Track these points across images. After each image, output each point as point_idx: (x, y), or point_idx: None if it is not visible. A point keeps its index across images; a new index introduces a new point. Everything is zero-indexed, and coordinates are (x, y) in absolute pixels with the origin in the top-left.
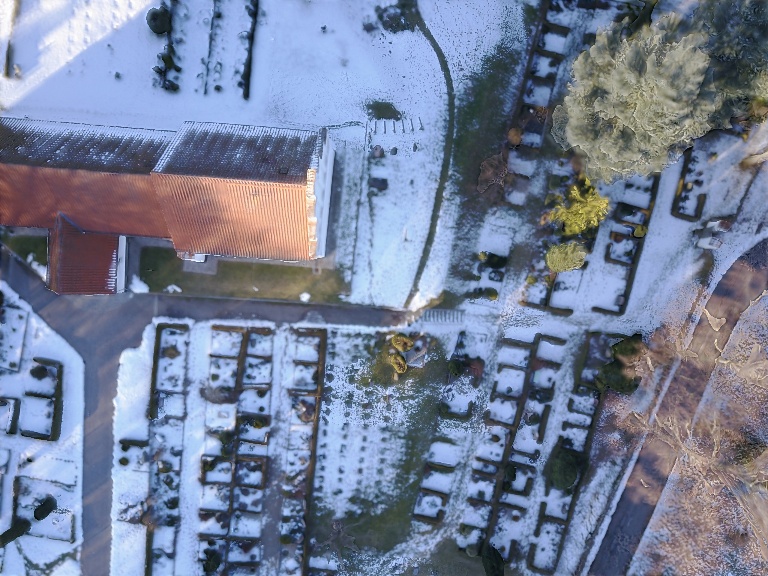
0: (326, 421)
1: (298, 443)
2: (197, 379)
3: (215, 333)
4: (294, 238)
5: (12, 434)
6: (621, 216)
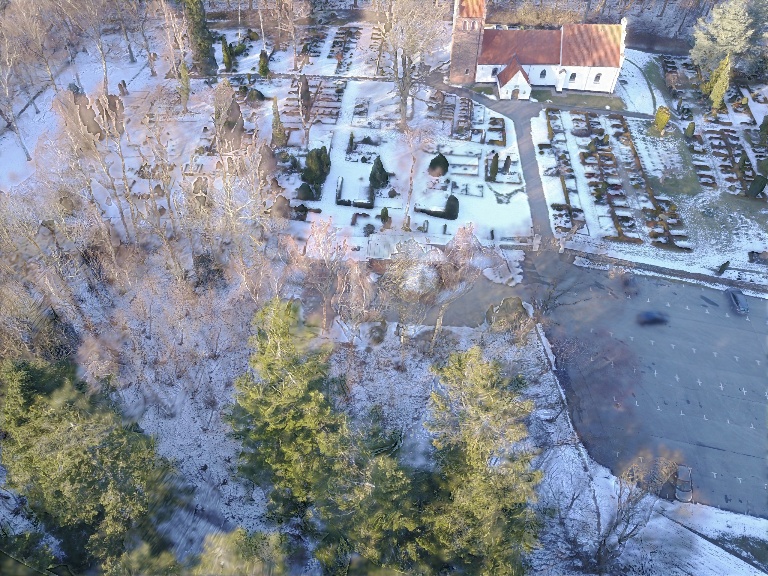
0: (636, 146)
1: (626, 152)
2: (568, 128)
3: (572, 115)
4: (614, 54)
5: (482, 144)
6: (733, 100)
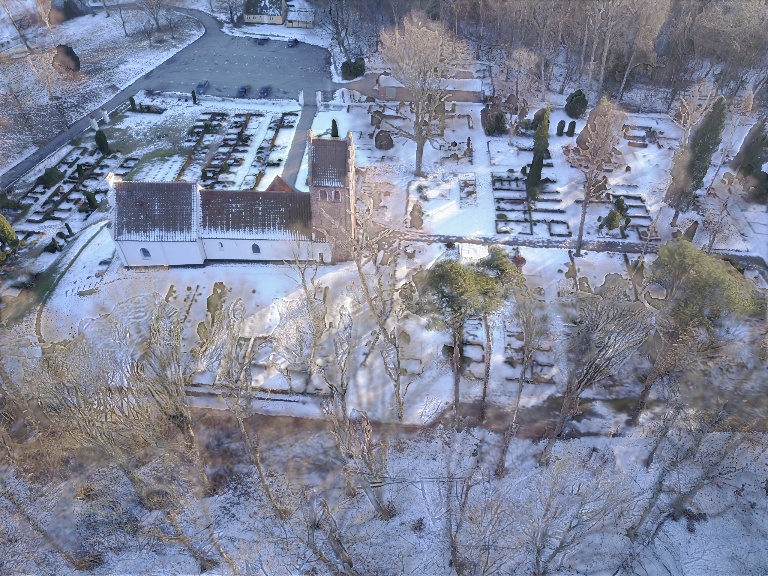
0: None
1: None
2: (235, 187)
3: None
4: None
5: None
6: None
